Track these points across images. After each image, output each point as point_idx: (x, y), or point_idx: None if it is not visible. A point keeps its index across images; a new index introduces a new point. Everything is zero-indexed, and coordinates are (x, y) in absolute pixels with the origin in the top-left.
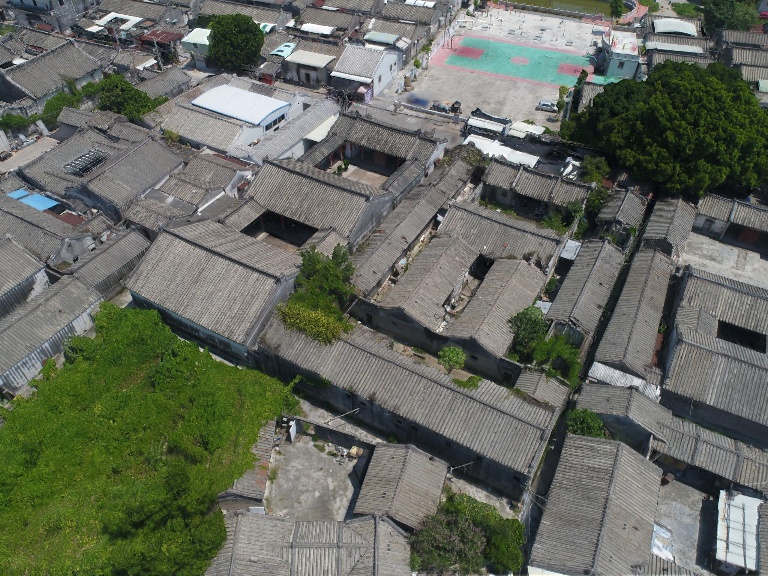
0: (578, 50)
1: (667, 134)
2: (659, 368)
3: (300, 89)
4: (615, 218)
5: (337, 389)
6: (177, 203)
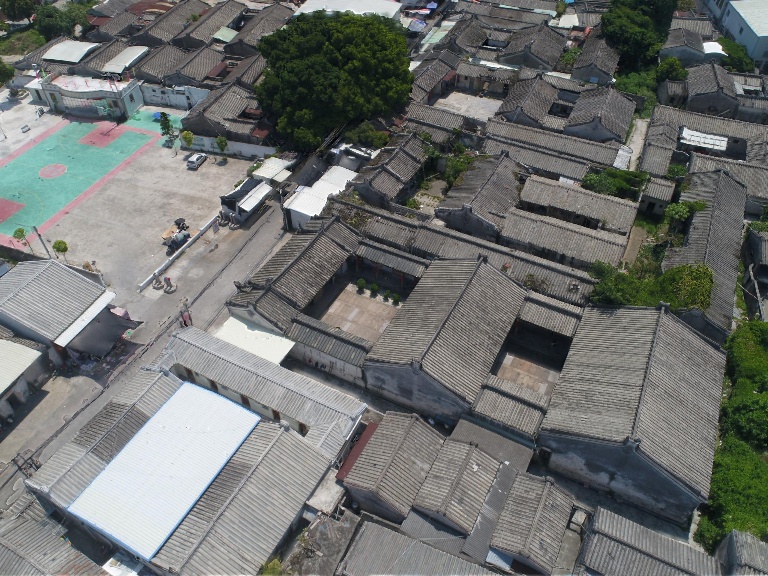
0: (46, 126)
1: (388, 66)
2: (606, 142)
3: (34, 420)
4: (452, 130)
5: None
6: (496, 496)
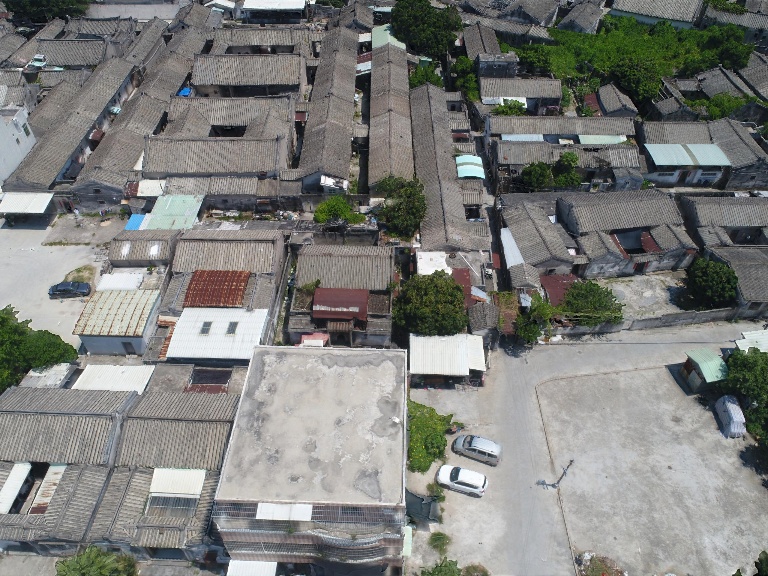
0: None
1: None
2: None
3: None
4: None
5: (750, 32)
6: None
